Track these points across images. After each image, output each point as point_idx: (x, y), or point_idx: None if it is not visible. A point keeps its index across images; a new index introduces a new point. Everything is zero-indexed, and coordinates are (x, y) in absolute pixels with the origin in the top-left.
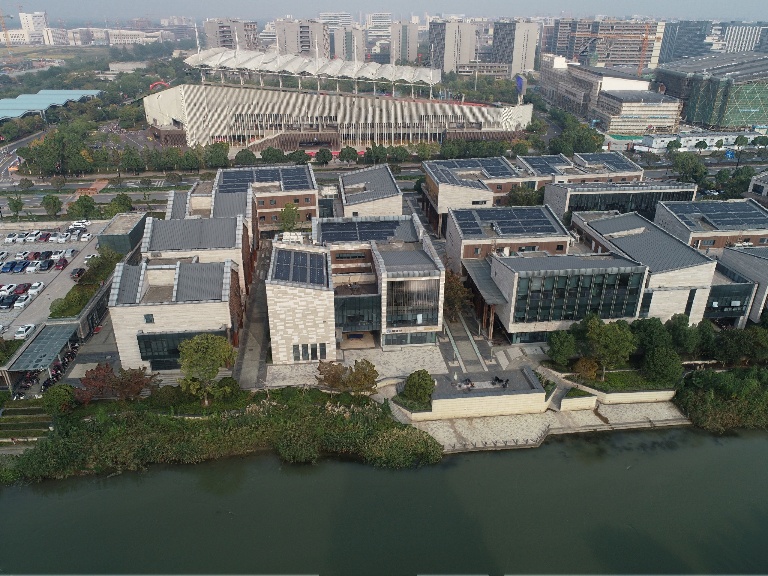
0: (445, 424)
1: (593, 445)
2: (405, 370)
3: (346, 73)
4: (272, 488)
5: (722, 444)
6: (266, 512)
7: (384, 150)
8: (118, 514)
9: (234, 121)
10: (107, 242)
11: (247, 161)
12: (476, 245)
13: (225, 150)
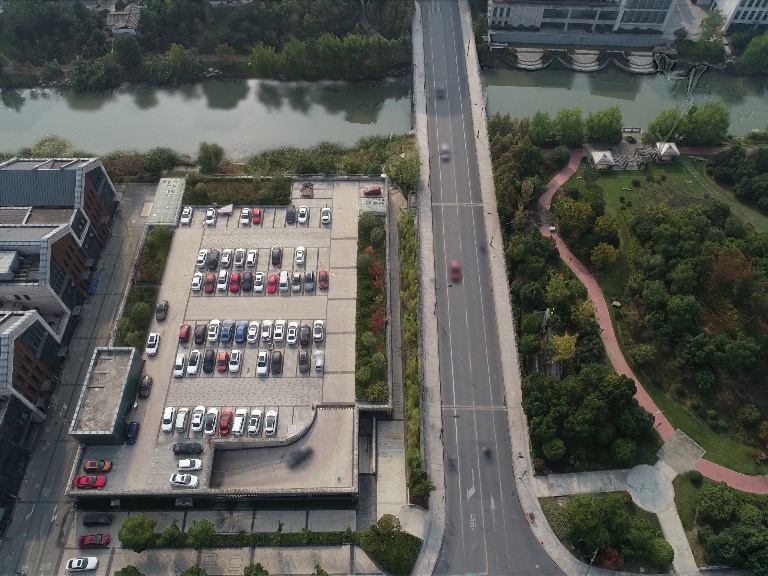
0: None
1: None
2: None
3: None
4: None
5: None
6: (60, 135)
7: None
8: (128, 137)
9: None
10: None
11: None
12: None
13: None
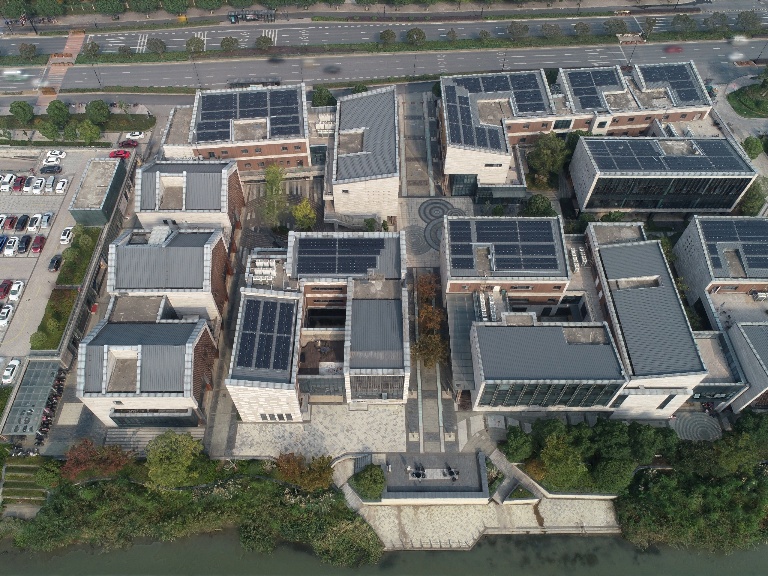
0: (392, 512)
1: (520, 552)
2: (365, 443)
3: None
4: (235, 567)
5: (639, 564)
6: None
7: None
8: None
9: None
10: (81, 215)
11: (243, 5)
12: (464, 283)
13: None
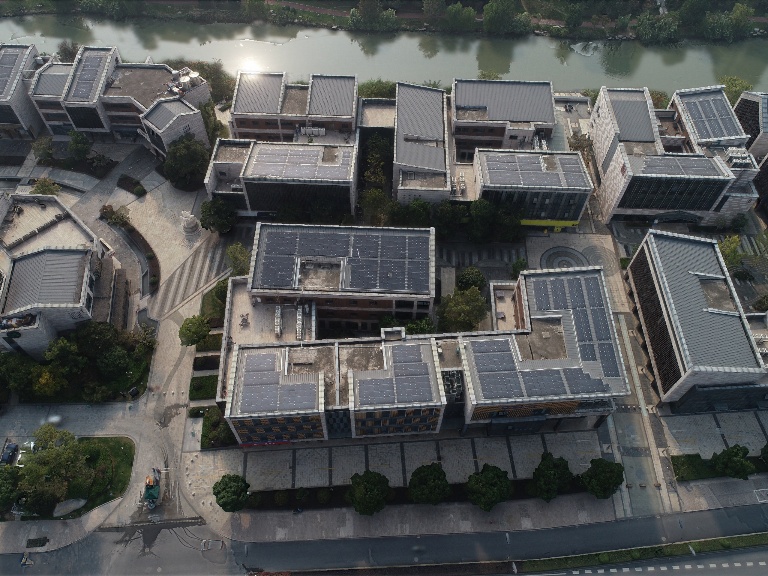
0: None
1: None
2: None
3: None
4: None
5: None
6: (660, 81)
7: None
8: None
9: None
10: None
11: None
12: None
13: None
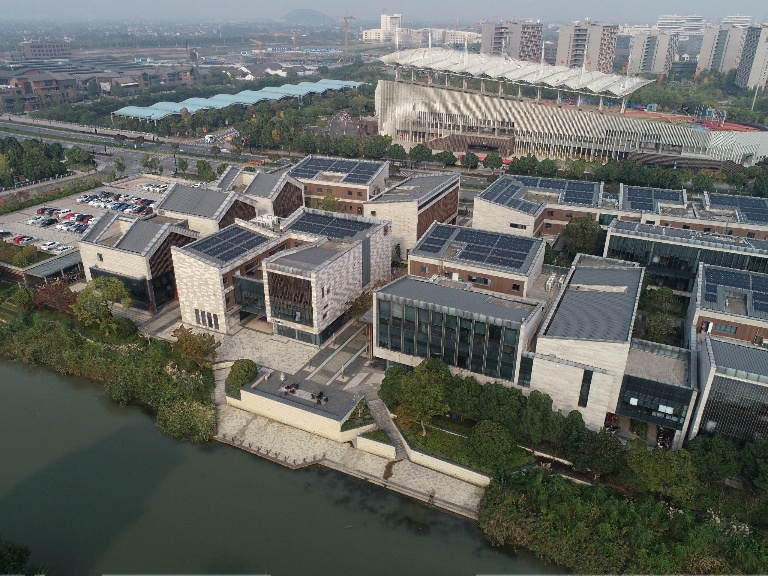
0: (247, 416)
1: (345, 491)
2: (264, 359)
3: (527, 78)
4: (90, 412)
5: (480, 556)
6: (55, 424)
7: (535, 162)
8: None
9: (418, 118)
10: None
11: (395, 155)
12: (423, 263)
13: (384, 143)
